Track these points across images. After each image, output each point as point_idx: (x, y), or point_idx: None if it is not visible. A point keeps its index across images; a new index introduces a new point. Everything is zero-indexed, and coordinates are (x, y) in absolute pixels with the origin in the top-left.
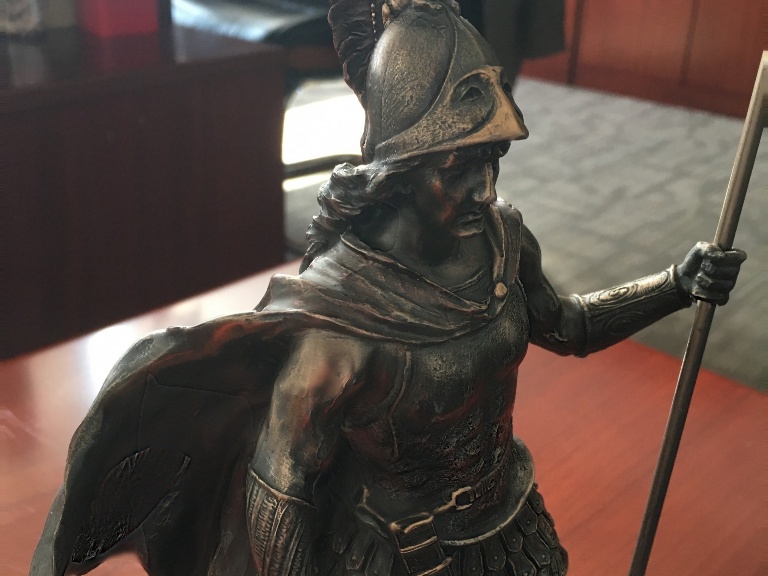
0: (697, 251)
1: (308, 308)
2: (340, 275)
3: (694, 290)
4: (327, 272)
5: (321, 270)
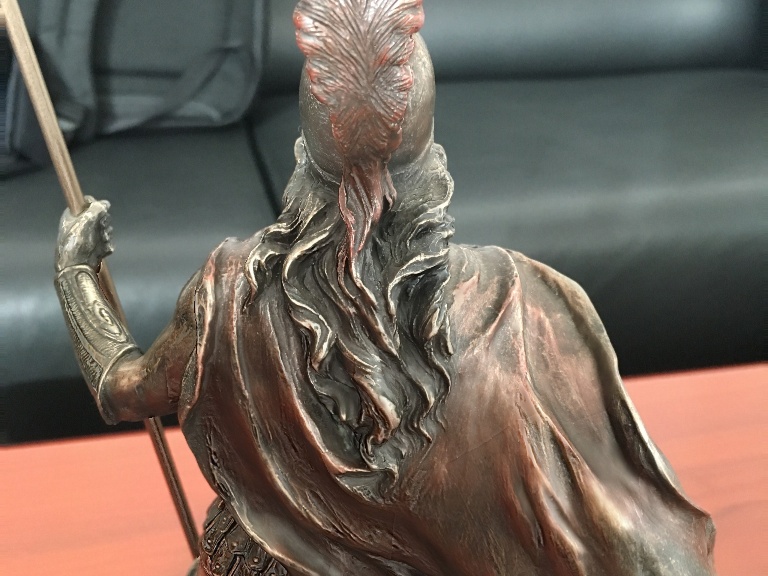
0: (99, 218)
1: (511, 256)
2: (469, 251)
3: (112, 248)
4: (475, 259)
5: (478, 264)
